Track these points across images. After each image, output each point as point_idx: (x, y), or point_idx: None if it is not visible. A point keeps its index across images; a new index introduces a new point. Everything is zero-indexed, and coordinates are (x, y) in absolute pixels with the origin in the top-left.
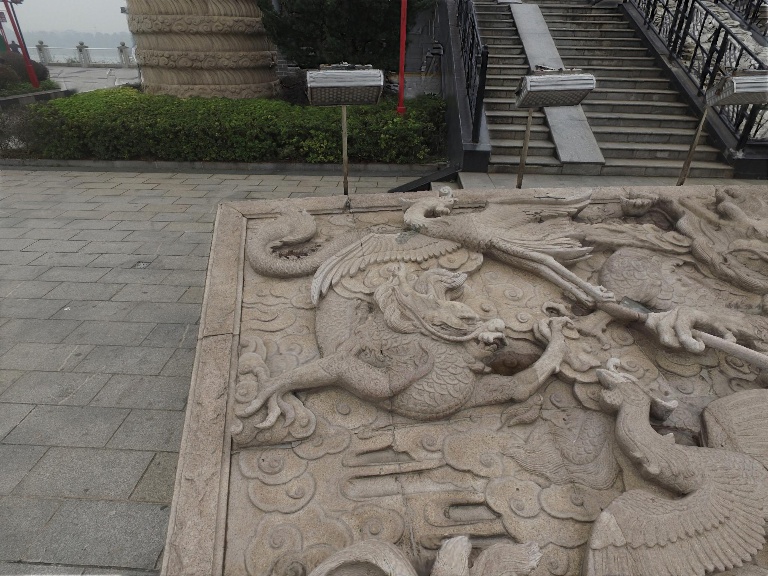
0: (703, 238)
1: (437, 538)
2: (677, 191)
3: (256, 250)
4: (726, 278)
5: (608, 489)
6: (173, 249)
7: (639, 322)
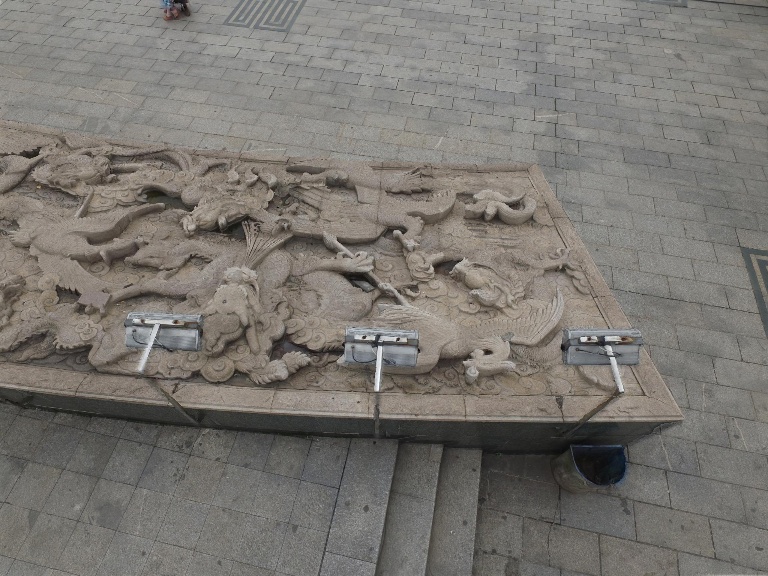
0: (279, 317)
1: None
2: (221, 392)
3: None
4: None
5: None
6: None
7: None
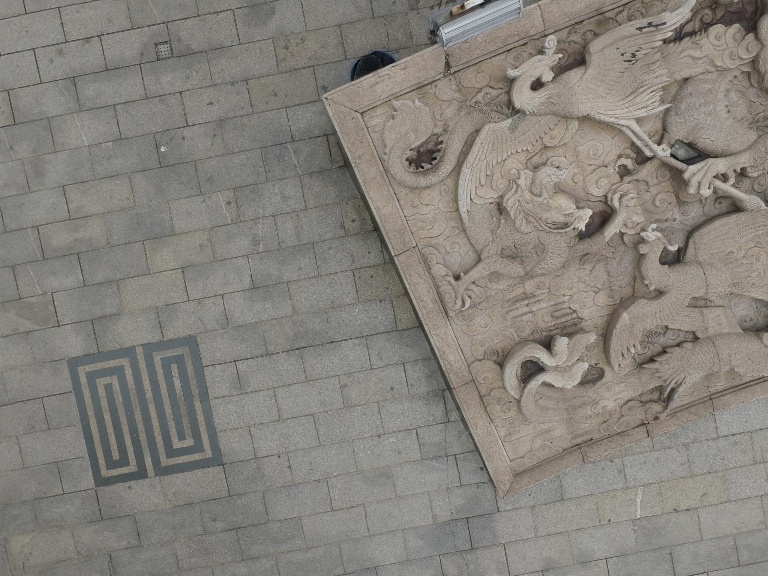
0: None
1: (549, 327)
2: None
3: (400, 173)
4: (766, 90)
5: (626, 286)
6: (171, 5)
7: (679, 169)
